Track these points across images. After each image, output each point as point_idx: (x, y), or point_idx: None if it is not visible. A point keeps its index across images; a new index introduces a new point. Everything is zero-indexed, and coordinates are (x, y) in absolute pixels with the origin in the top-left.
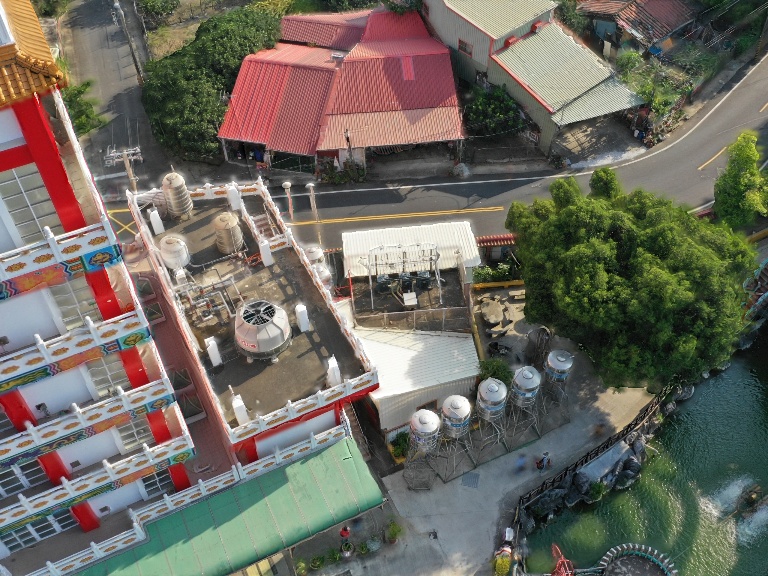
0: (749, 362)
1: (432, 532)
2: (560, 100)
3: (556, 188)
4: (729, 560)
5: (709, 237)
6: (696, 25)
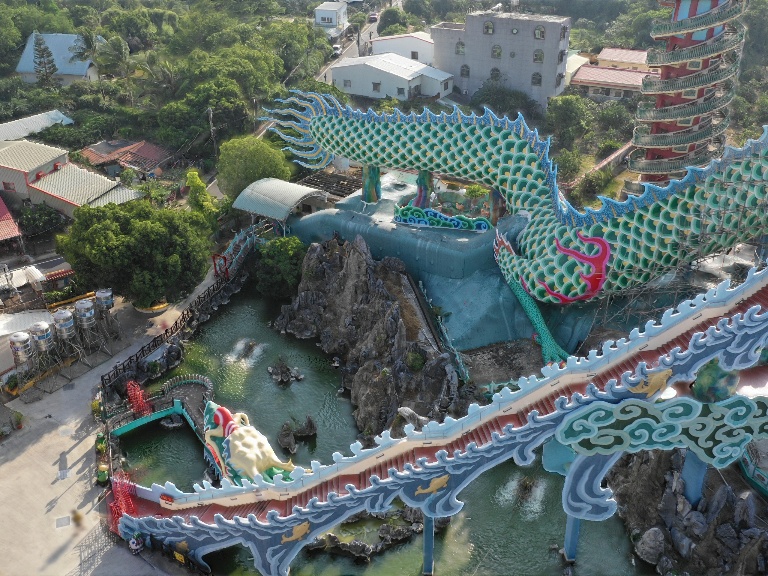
0: (244, 301)
1: (47, 416)
2: (85, 200)
3: (77, 211)
4: (243, 375)
5: (175, 212)
6: (176, 160)
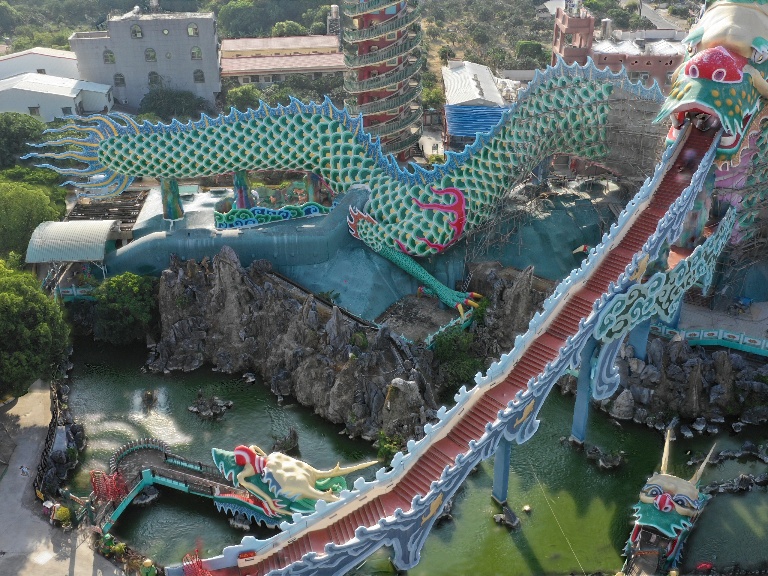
0: (81, 361)
1: None
2: None
3: None
4: (169, 425)
5: None
6: None
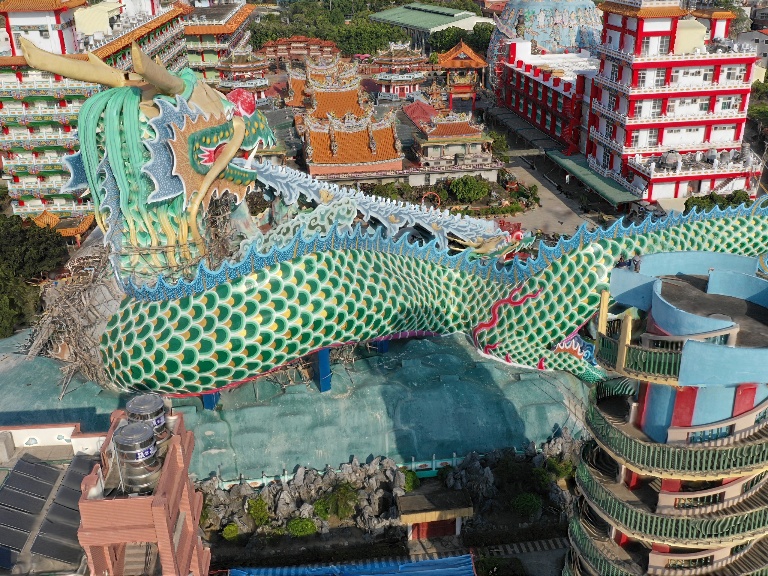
0: None
1: None
2: None
3: None
4: None
5: None
6: None
